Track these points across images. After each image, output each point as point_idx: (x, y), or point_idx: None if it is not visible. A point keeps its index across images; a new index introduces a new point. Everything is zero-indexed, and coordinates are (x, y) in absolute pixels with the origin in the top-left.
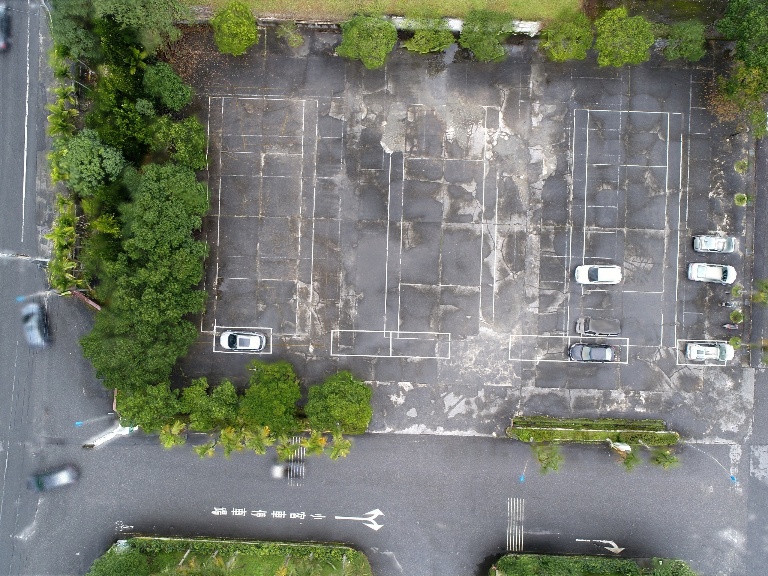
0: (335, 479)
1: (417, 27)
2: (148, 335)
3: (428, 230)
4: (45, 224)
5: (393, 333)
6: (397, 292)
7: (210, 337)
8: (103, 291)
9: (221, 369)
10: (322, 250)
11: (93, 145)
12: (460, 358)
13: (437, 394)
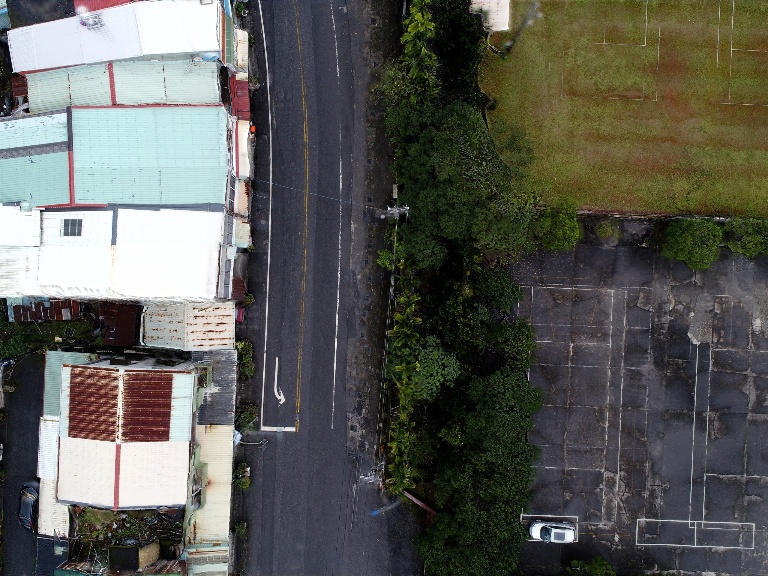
0: None
1: (743, 230)
2: (495, 547)
3: (734, 421)
4: (355, 411)
5: (698, 523)
6: (702, 482)
7: None
8: (439, 495)
9: (527, 557)
10: (629, 440)
11: (438, 355)
12: (764, 548)
13: None
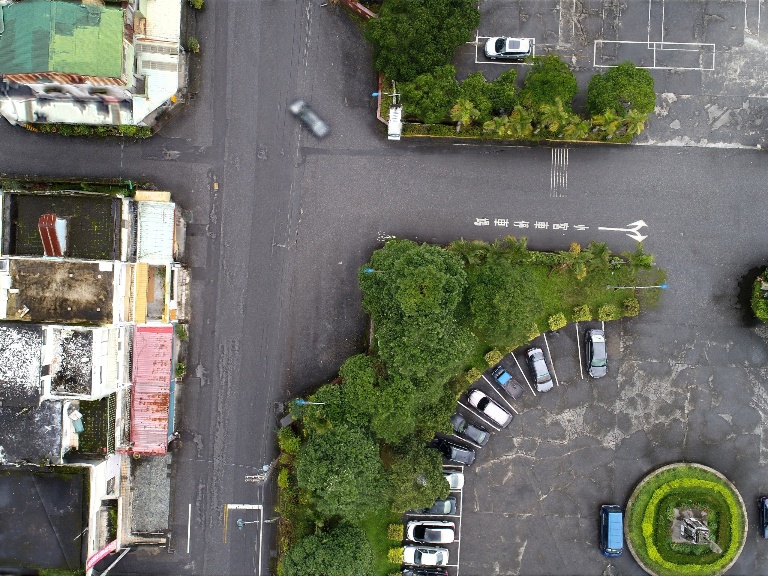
0: (598, 190)
1: None
2: (444, 8)
3: None
4: None
5: (657, 44)
6: (661, 2)
7: (472, 48)
8: None
9: None
10: None
11: None
12: (725, 69)
13: (701, 105)
